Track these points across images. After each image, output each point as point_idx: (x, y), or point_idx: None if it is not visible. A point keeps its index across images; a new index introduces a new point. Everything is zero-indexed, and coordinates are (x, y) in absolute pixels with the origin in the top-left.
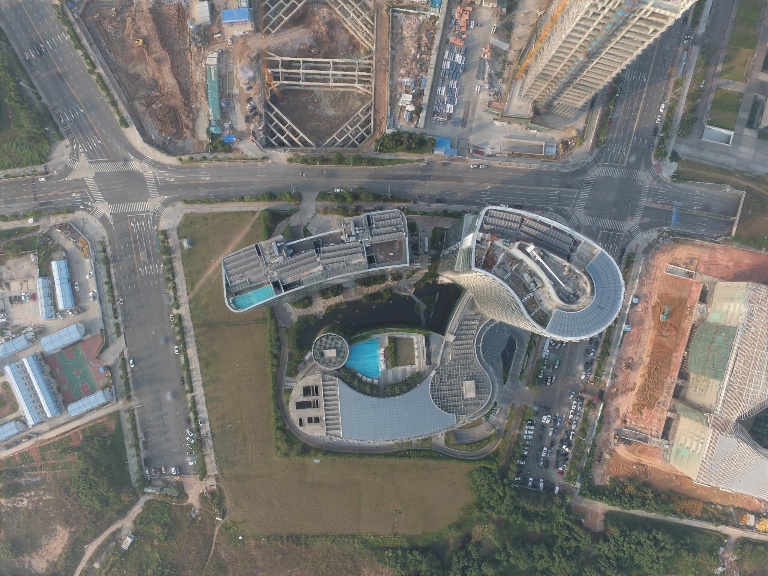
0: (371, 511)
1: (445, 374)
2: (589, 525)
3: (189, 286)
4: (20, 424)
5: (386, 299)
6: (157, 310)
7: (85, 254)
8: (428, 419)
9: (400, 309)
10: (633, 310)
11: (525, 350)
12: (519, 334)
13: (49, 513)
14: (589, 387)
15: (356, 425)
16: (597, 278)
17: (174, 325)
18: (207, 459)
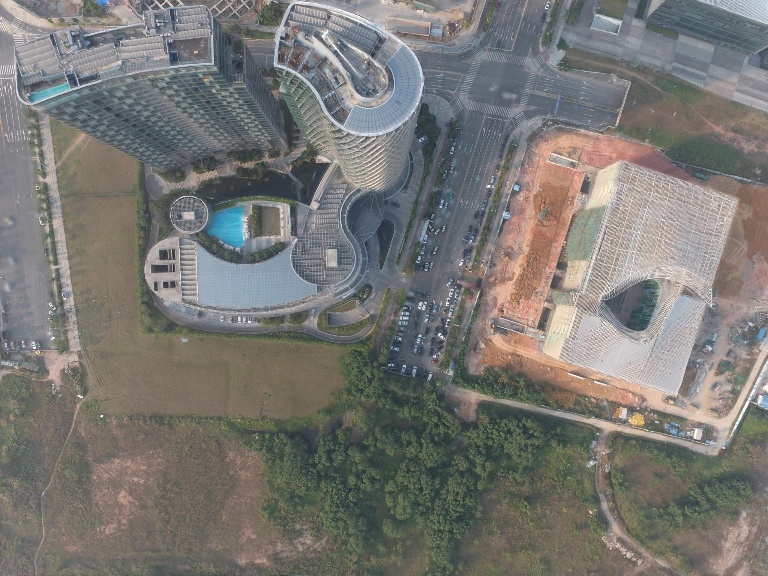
0: (239, 393)
1: (307, 242)
2: (462, 415)
3: (57, 155)
4: None
5: (261, 175)
6: (23, 178)
7: None
8: (288, 288)
9: (276, 187)
10: (515, 198)
11: (403, 234)
12: (398, 218)
13: None
14: (467, 275)
15: (213, 291)
16: (397, 73)
17: (37, 192)
18: (70, 334)
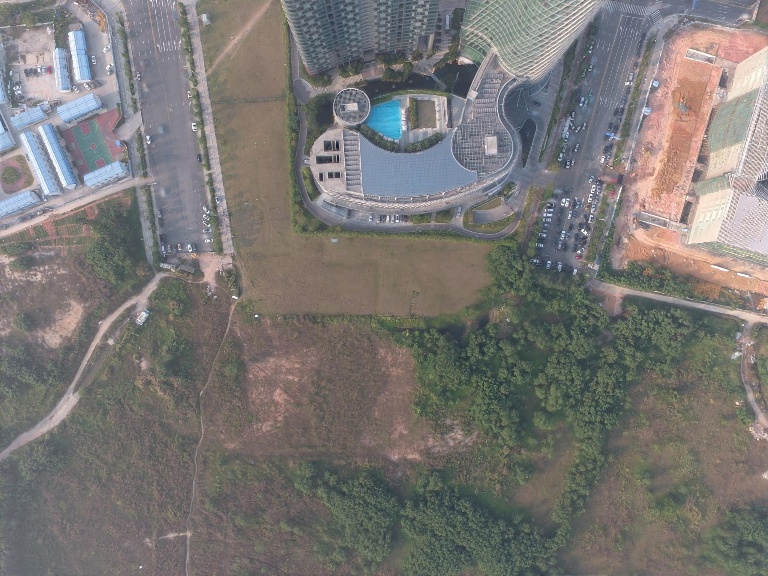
0: (388, 292)
1: (467, 131)
2: (607, 309)
3: (207, 63)
4: (35, 195)
5: (406, 77)
6: (175, 87)
7: (102, 28)
8: (449, 176)
9: None
10: (653, 95)
11: (545, 133)
12: (539, 117)
13: (63, 288)
14: (608, 171)
15: (377, 180)
16: None
17: None
18: (224, 237)
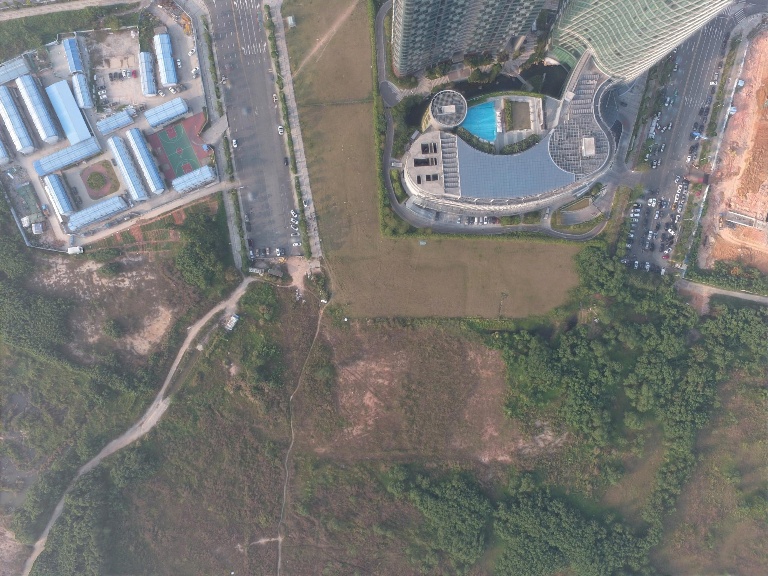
0: (477, 294)
1: (564, 132)
2: None
3: (293, 65)
4: (122, 201)
5: (493, 78)
6: (260, 90)
7: (187, 31)
8: (547, 177)
9: None
10: (738, 94)
11: (631, 133)
12: (625, 117)
13: (151, 294)
14: (694, 171)
15: (475, 183)
16: None
17: None
18: (311, 241)
